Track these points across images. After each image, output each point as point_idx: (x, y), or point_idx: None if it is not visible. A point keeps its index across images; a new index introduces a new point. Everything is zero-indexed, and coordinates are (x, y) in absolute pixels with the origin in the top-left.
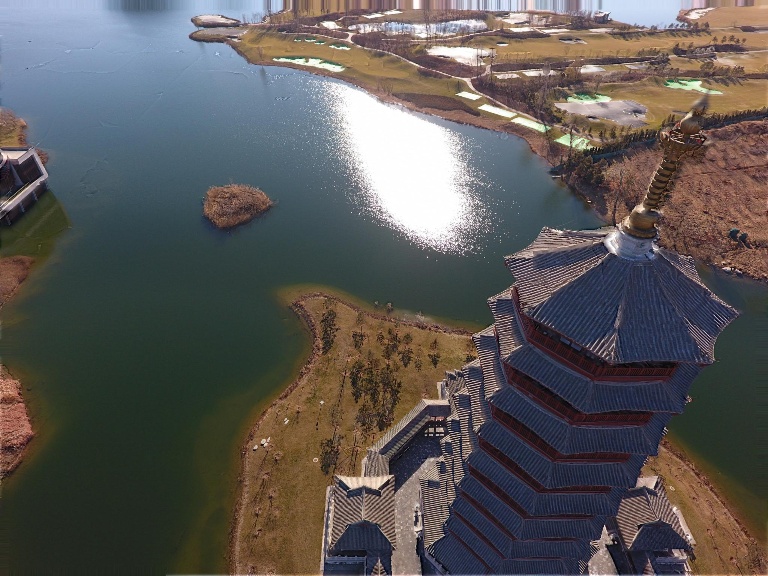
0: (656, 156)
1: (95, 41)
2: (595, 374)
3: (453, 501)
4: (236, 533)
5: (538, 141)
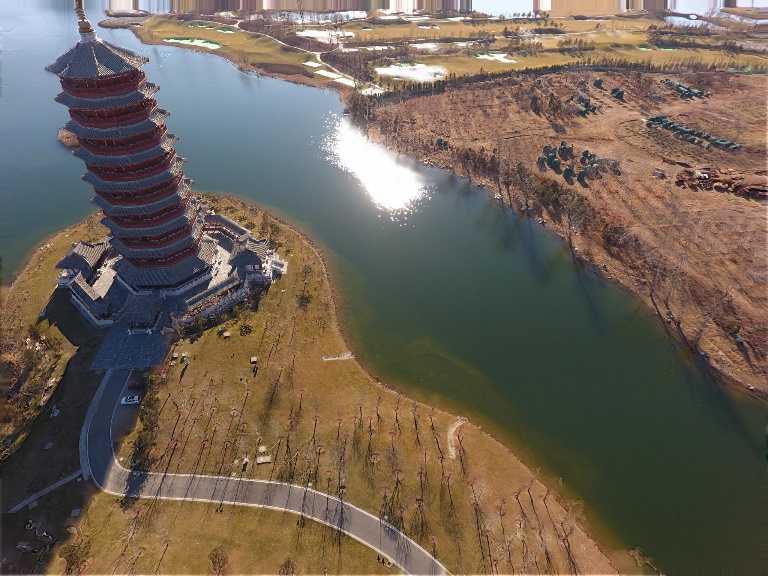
0: (425, 100)
1: (11, 27)
2: (74, 92)
3: None
4: (14, 283)
5: (347, 93)
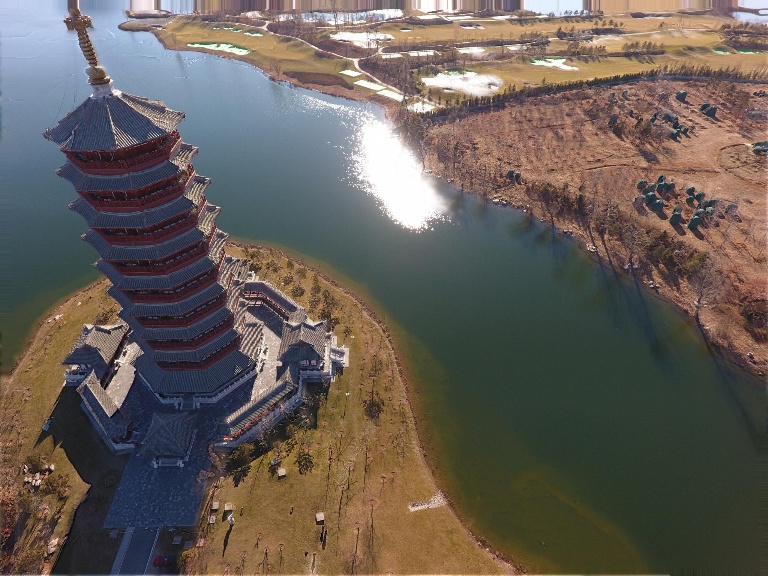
0: (484, 118)
1: (28, 31)
2: (82, 168)
3: (120, 312)
4: (14, 372)
5: (393, 109)
